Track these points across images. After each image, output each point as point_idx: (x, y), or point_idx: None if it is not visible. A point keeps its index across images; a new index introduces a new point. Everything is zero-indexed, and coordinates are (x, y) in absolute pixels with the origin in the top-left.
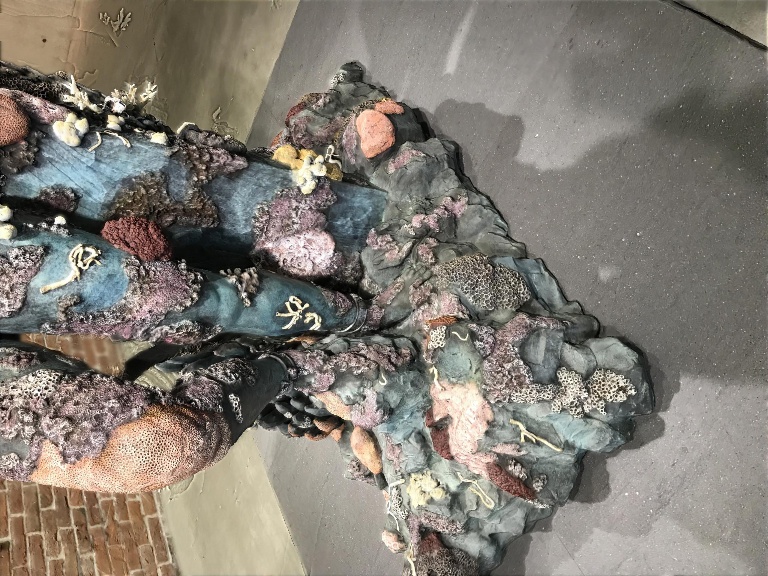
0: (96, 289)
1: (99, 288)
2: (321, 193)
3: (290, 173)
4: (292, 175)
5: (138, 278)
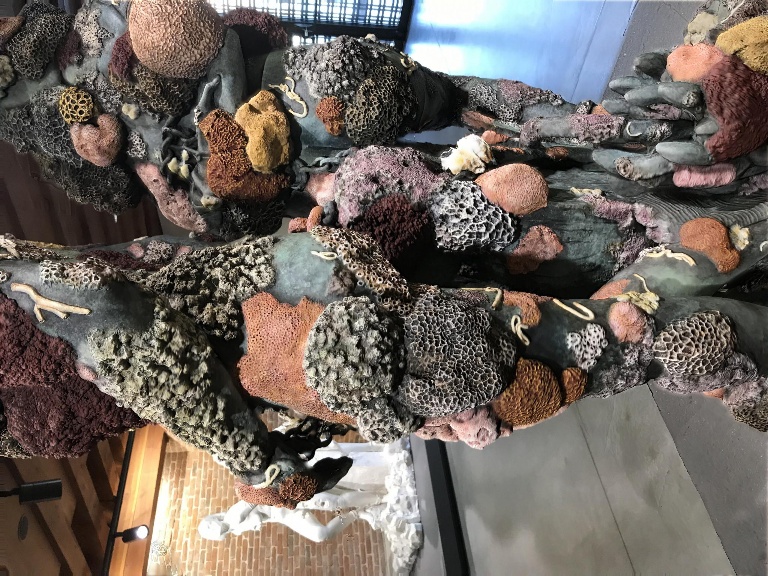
0: None
1: None
2: None
3: None
4: None
5: None
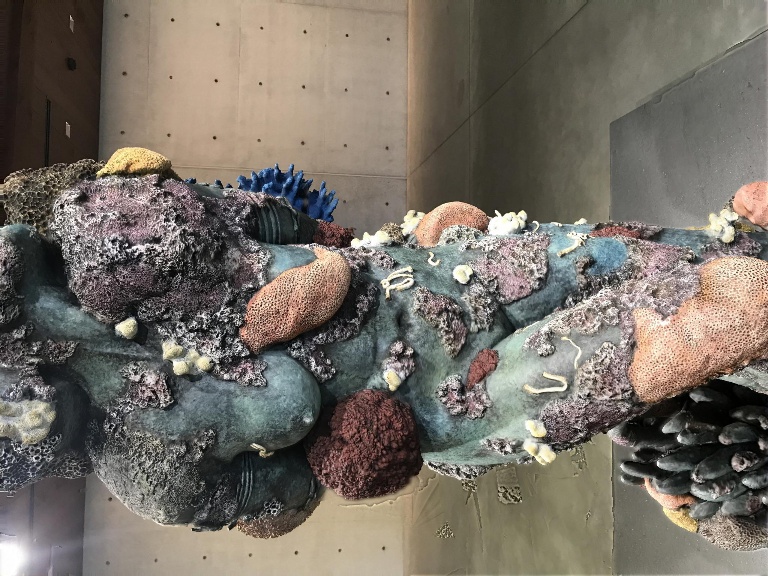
0: (601, 251)
1: (604, 250)
2: (743, 243)
3: (703, 231)
4: (706, 232)
5: (632, 243)
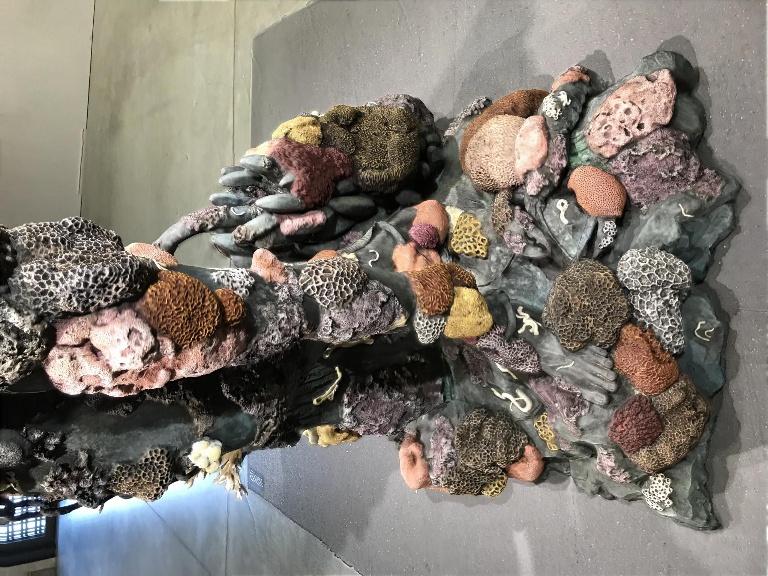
0: None
1: None
2: None
3: None
4: None
5: None
